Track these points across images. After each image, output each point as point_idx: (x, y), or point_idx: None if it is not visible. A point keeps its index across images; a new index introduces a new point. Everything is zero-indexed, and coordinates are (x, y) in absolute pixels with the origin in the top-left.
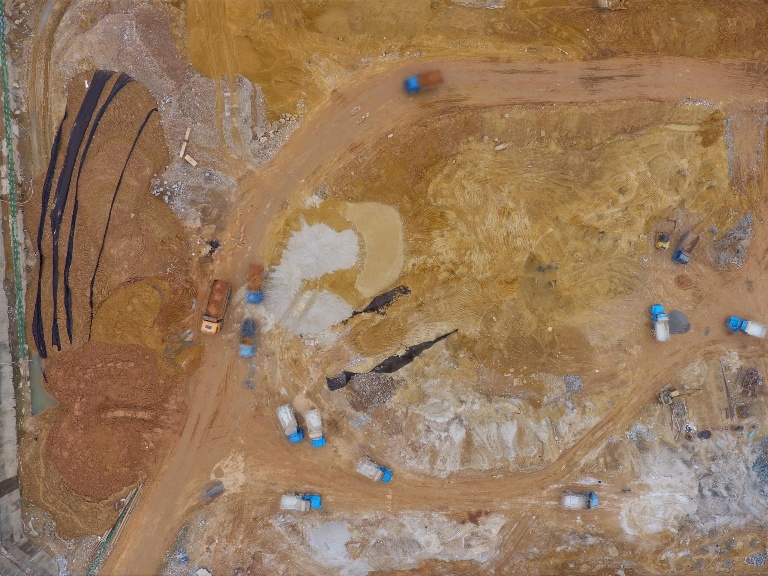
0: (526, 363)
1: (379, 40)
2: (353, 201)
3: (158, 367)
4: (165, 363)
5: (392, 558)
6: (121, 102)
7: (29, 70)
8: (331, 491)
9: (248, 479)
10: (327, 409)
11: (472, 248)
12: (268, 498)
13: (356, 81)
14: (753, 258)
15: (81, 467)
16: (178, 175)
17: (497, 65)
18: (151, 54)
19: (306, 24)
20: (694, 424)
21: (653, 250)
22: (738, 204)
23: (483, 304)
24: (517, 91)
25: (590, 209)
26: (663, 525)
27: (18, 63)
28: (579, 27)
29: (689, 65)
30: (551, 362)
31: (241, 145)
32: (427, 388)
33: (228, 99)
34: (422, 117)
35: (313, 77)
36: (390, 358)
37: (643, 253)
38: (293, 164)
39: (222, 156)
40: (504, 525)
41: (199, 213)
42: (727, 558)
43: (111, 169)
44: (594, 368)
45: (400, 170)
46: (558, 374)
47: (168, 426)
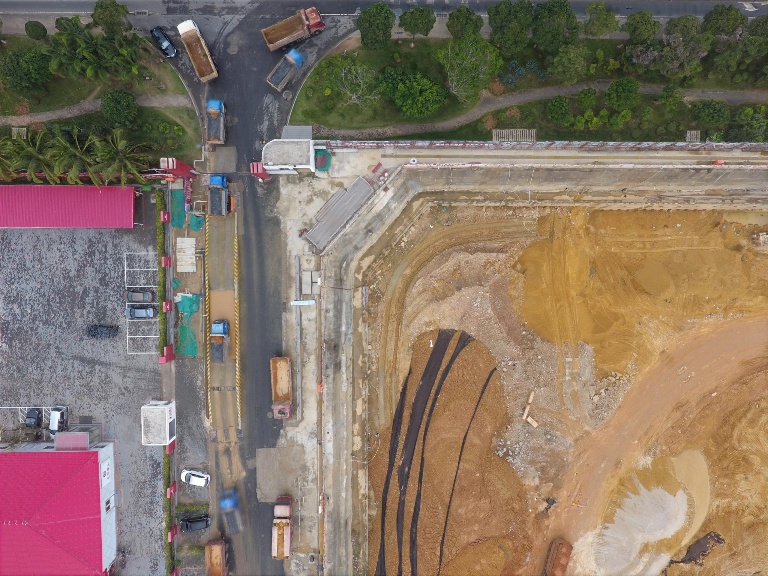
0: None
1: (703, 300)
2: (675, 455)
3: None
4: None
5: None
6: (464, 362)
7: (382, 332)
8: None
9: None
10: None
11: None
12: None
13: (683, 341)
14: None
15: None
16: (519, 435)
17: None
18: (498, 320)
19: None
20: None
21: None
22: None
23: None
24: None
25: None
26: None
27: (372, 326)
28: None
29: None
30: None
31: (580, 407)
32: None
33: (570, 364)
34: (742, 374)
35: (643, 338)
36: None
37: None
38: (627, 425)
39: (561, 417)
40: None
41: (539, 472)
42: None
43: (456, 428)
44: None
45: (713, 420)
46: None
47: None
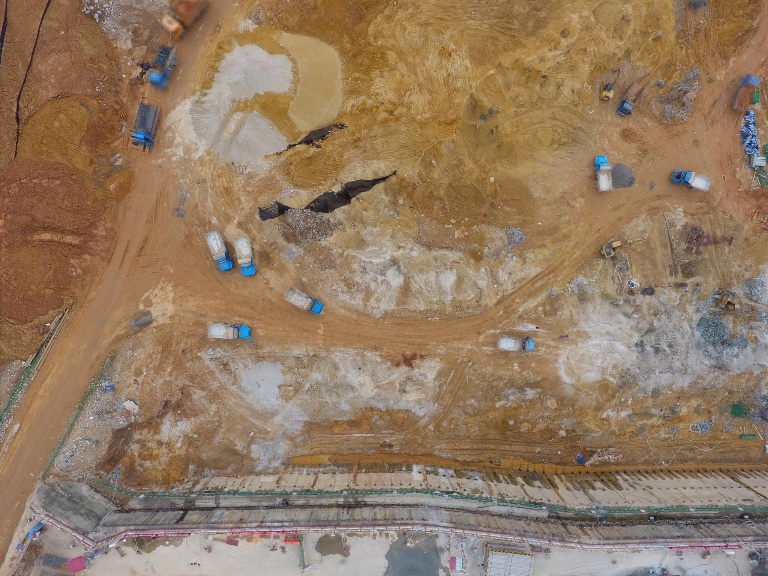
0: (468, 214)
1: None
2: (289, 31)
3: (86, 189)
4: (93, 185)
5: (326, 402)
6: None
7: None
8: (262, 324)
9: (177, 310)
10: (258, 240)
11: (412, 89)
12: (197, 330)
13: None
14: (699, 112)
15: (4, 285)
16: None
17: None
18: None
19: None
20: (637, 280)
21: (598, 102)
22: (685, 58)
23: (421, 144)
24: None
25: (531, 51)
26: (601, 374)
27: None
28: None
29: None
30: (493, 214)
31: None
32: (366, 236)
33: None
34: None
35: None
36: (325, 194)
37: (587, 104)
38: None
39: None
40: (440, 372)
41: (130, 33)
42: (672, 424)
43: None
44: (536, 220)
45: (339, 5)
46: (500, 226)
47: (96, 253)
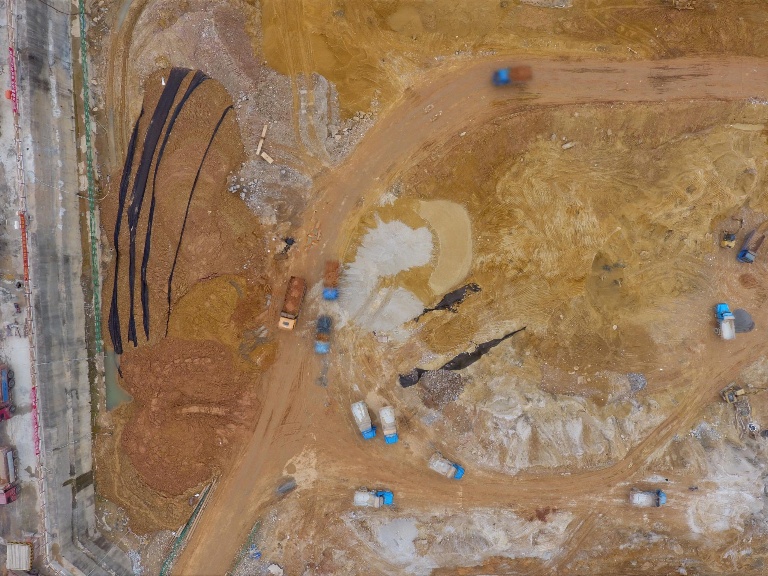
0: (590, 361)
1: (452, 39)
2: (425, 199)
3: (233, 363)
4: (240, 359)
5: (459, 555)
6: (197, 99)
7: (107, 67)
8: (402, 488)
9: (320, 475)
10: (399, 406)
11: (540, 246)
12: (340, 494)
13: (429, 79)
14: None
15: (158, 462)
16: (254, 172)
17: (567, 64)
18: (228, 52)
19: (378, 22)
20: (757, 423)
21: (717, 249)
22: None
23: (551, 302)
24: (586, 90)
25: (658, 208)
26: (729, 523)
27: (96, 60)
28: (647, 26)
29: (756, 64)
30: (615, 360)
31: (317, 143)
32: (492, 386)
33: (304, 97)
34: (494, 115)
35: (387, 75)
36: (460, 355)
37: (708, 252)
38: (368, 162)
39: (298, 153)
40: (570, 523)
41: (275, 210)
42: None
43: (188, 166)
44: (658, 366)
45: (470, 168)
46: (622, 372)
47: (241, 422)
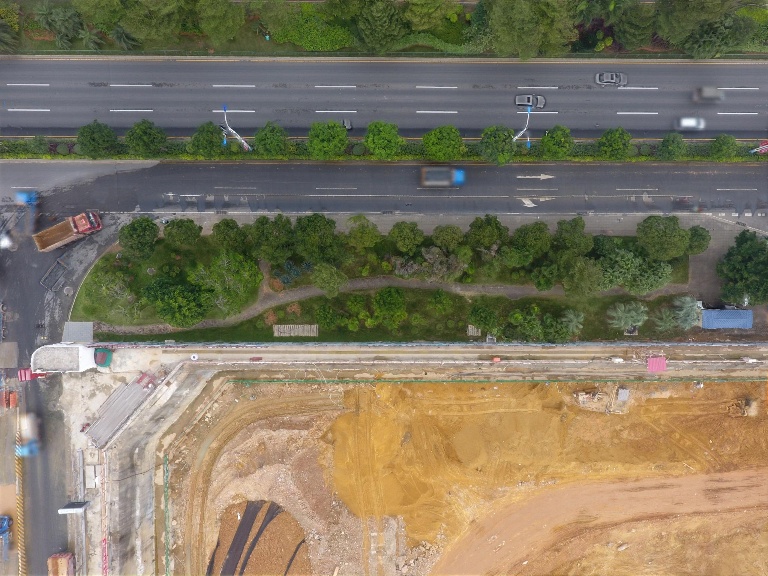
0: None
1: (515, 467)
2: None
3: None
4: None
5: None
6: (271, 535)
7: (187, 507)
8: None
9: None
10: None
11: None
12: None
13: (493, 510)
14: None
15: None
16: None
17: (625, 484)
18: (303, 495)
19: (444, 447)
20: None
21: None
22: None
23: None
24: (643, 506)
25: None
26: None
27: (177, 502)
28: (702, 438)
29: None
30: None
31: None
32: None
33: (375, 539)
34: (555, 541)
35: (453, 508)
36: None
37: None
38: None
39: None
40: None
41: None
42: None
43: None
44: None
45: None
46: None
47: None
